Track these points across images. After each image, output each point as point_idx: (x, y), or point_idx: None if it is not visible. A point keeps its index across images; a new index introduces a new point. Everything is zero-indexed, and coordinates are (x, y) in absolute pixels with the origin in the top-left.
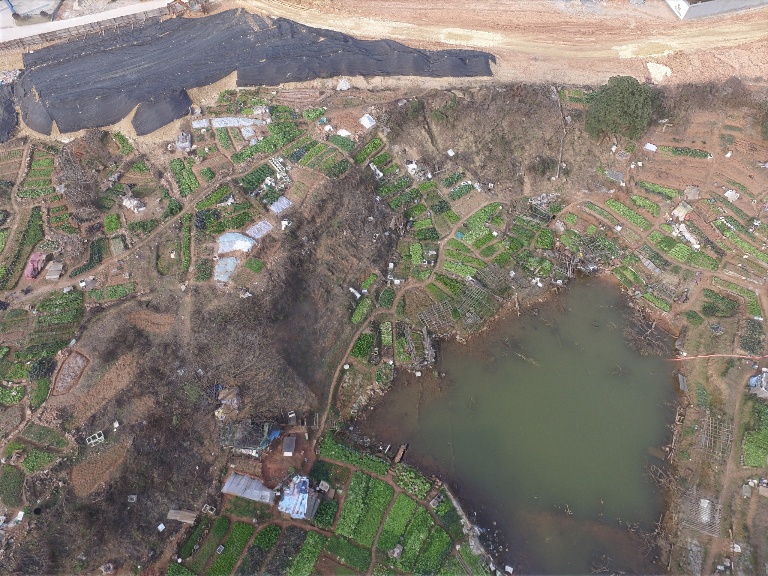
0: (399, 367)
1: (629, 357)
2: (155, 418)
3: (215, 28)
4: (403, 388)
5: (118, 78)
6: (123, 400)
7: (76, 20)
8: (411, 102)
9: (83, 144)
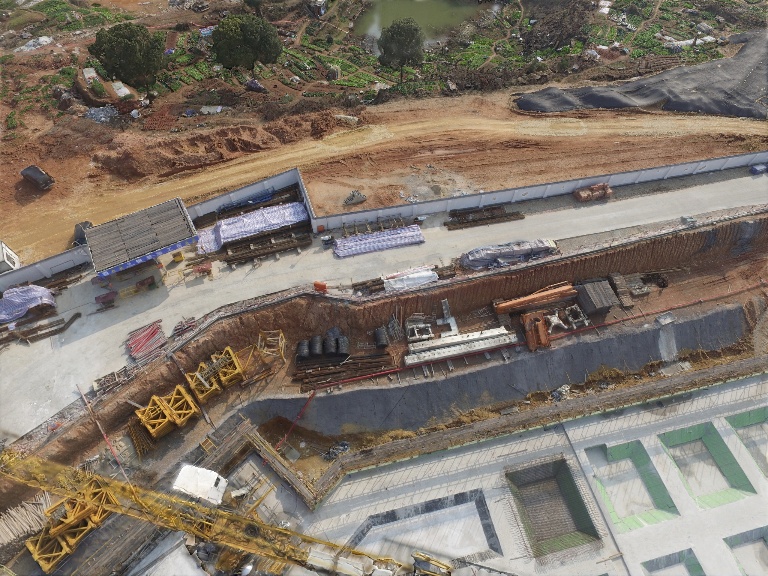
0: None
1: None
2: None
3: None
4: None
5: None
6: None
7: None
8: None
9: None
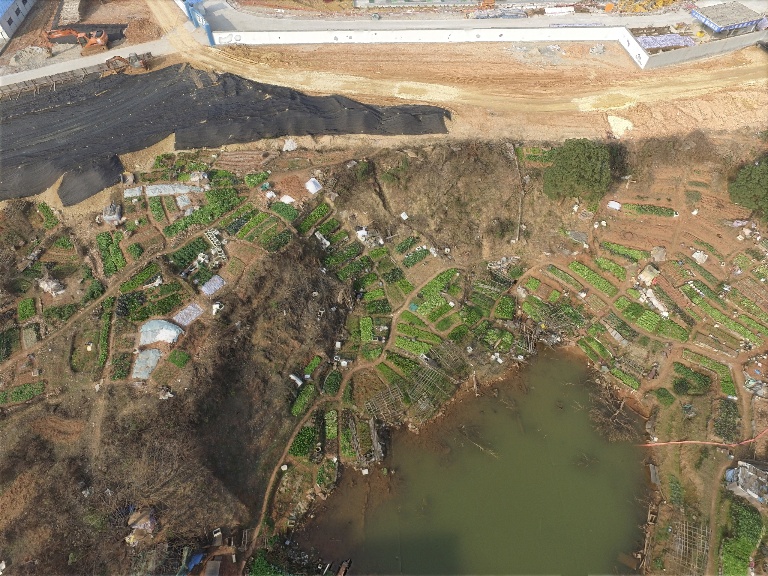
0: (344, 464)
1: (596, 443)
2: (50, 555)
3: (156, 85)
4: (348, 489)
5: (46, 143)
6: (14, 533)
7: (11, 77)
8: (360, 164)
9: (4, 217)
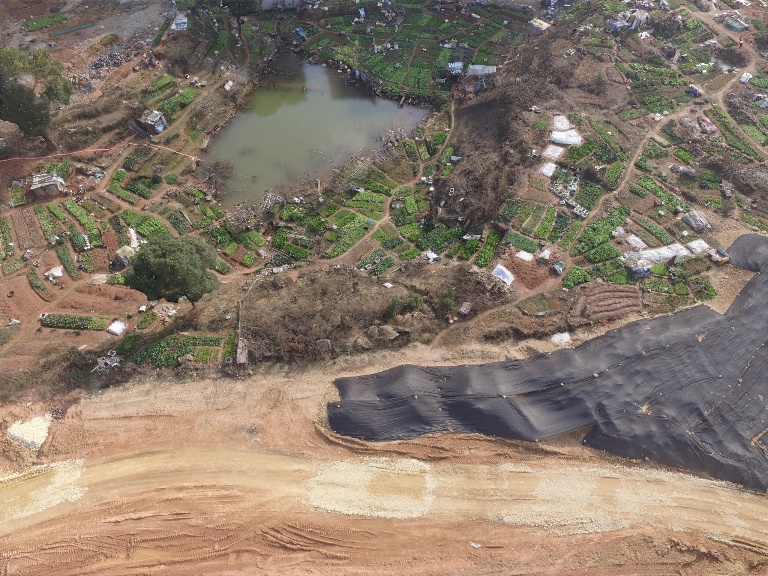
0: None
1: (236, 159)
2: None
3: None
4: None
5: None
6: (571, 65)
7: None
8: None
9: None
